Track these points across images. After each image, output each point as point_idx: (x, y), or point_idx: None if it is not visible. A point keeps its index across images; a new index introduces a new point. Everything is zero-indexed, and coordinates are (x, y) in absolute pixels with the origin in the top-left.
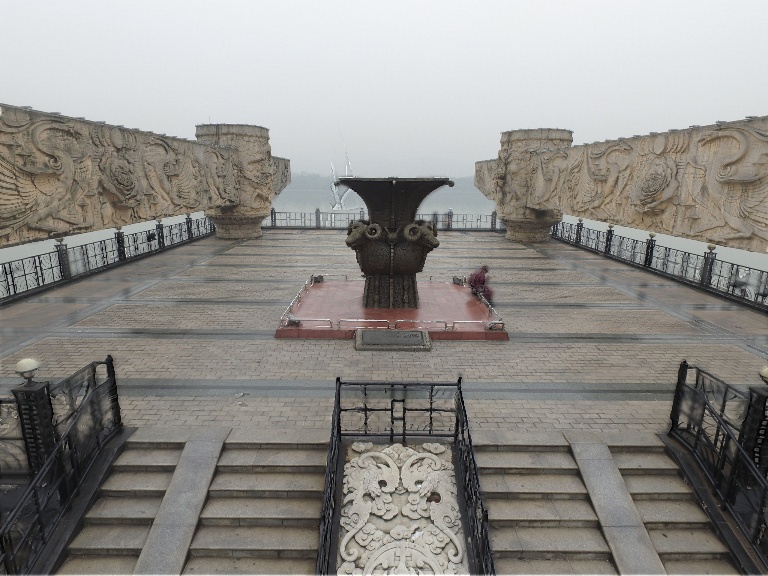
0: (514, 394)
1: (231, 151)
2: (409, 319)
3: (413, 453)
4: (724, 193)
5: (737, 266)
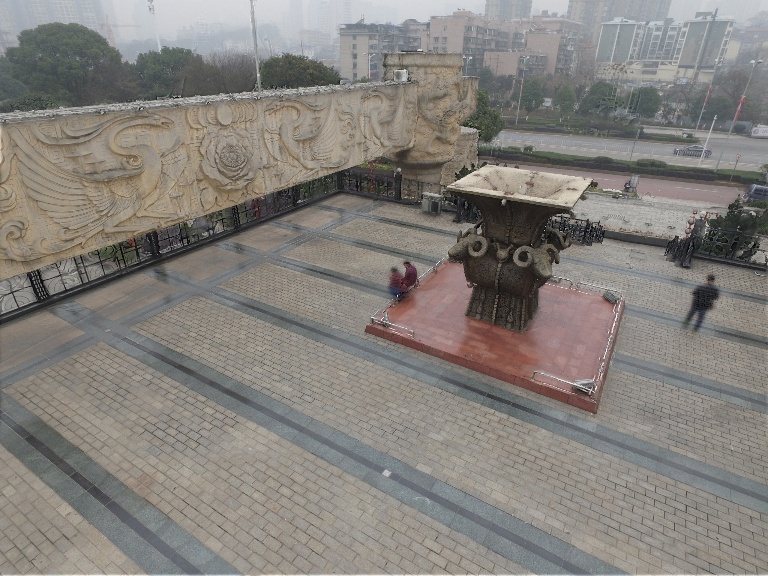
0: None
1: None
2: None
3: None
4: None
5: None
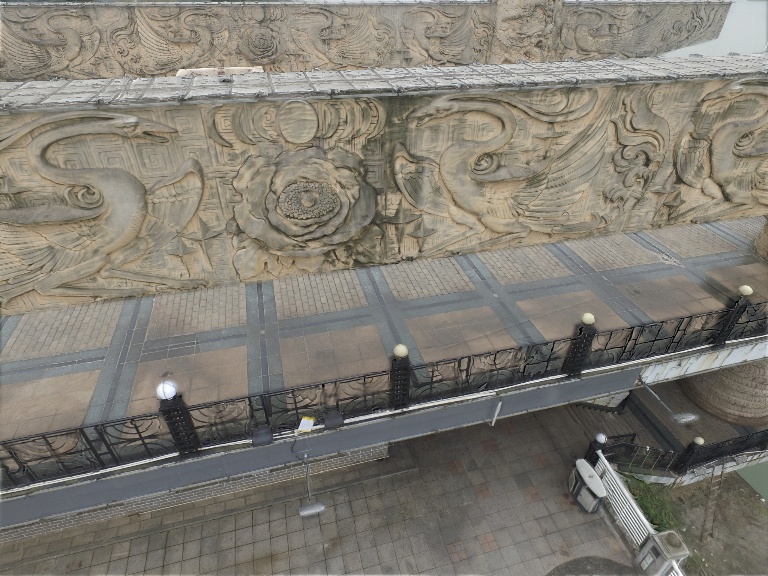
0: None
1: (477, 6)
2: None
3: None
4: None
5: (324, 383)
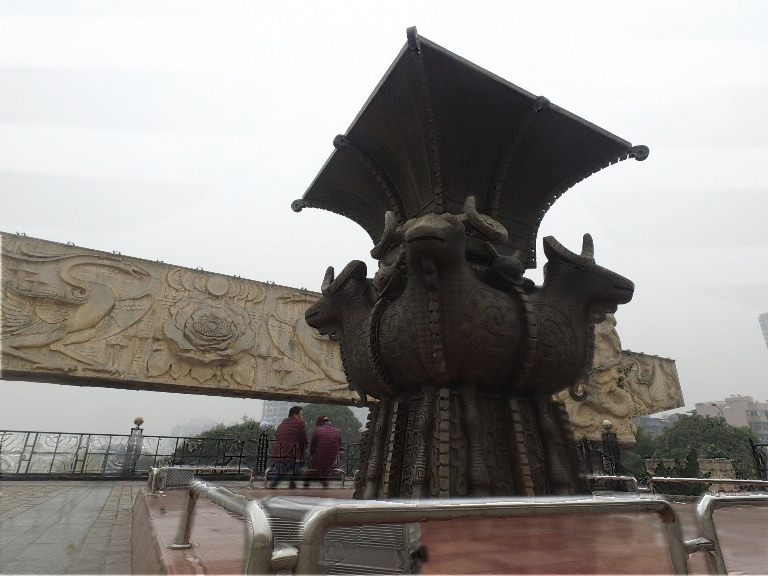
0: None
1: None
2: None
3: None
4: (324, 349)
5: (185, 439)
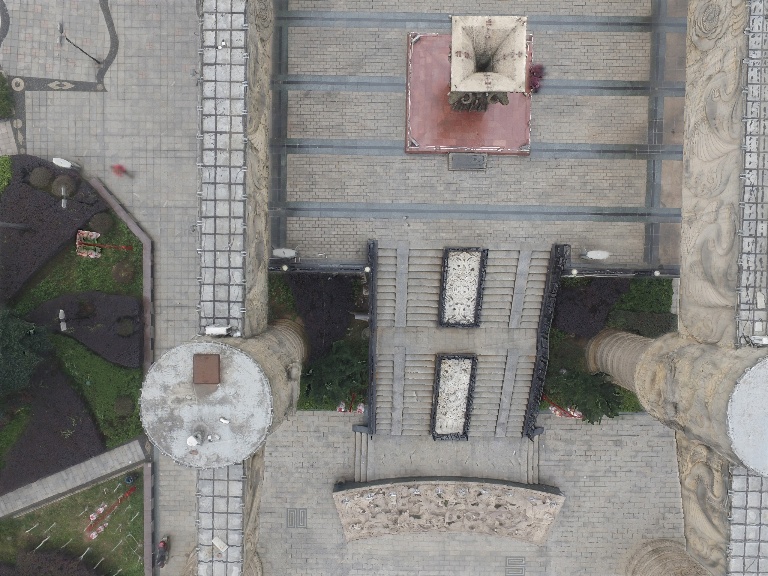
0: (513, 216)
1: None
2: (479, 132)
3: (469, 256)
4: (705, 103)
5: None
